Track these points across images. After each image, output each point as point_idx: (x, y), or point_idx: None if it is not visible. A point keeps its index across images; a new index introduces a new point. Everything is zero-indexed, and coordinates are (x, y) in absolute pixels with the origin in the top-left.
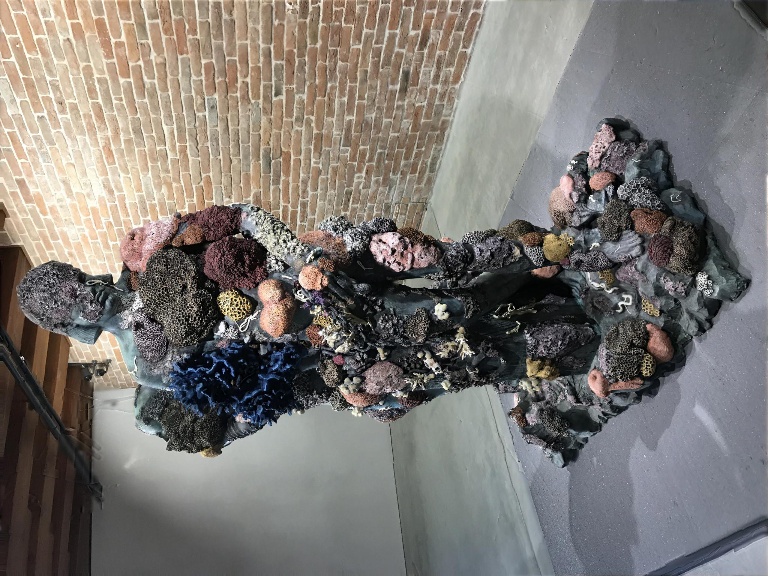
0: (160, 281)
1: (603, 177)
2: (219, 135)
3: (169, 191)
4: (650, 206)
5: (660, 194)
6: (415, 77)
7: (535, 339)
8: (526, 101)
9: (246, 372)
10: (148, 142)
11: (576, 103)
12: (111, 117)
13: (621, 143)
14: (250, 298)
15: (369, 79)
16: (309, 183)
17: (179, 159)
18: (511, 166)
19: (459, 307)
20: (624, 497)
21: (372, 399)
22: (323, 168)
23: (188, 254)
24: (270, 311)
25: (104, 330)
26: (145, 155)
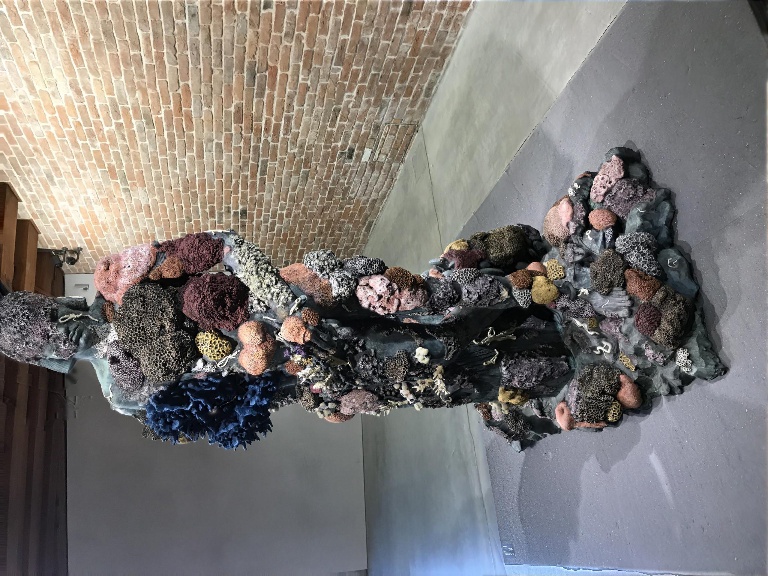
0: (137, 320)
1: (604, 217)
2: (200, 44)
3: (144, 97)
4: (646, 270)
5: (658, 253)
6: (420, 0)
7: (511, 373)
8: (536, 62)
9: (223, 401)
10: (121, 46)
11: (589, 105)
12: (79, 18)
13: (628, 185)
14: (230, 339)
15: None
16: (295, 98)
17: (155, 65)
18: (511, 125)
19: (440, 349)
20: (572, 498)
21: (345, 418)
22: (311, 85)
23: (166, 286)
24: (250, 354)
25: None
26: (118, 59)
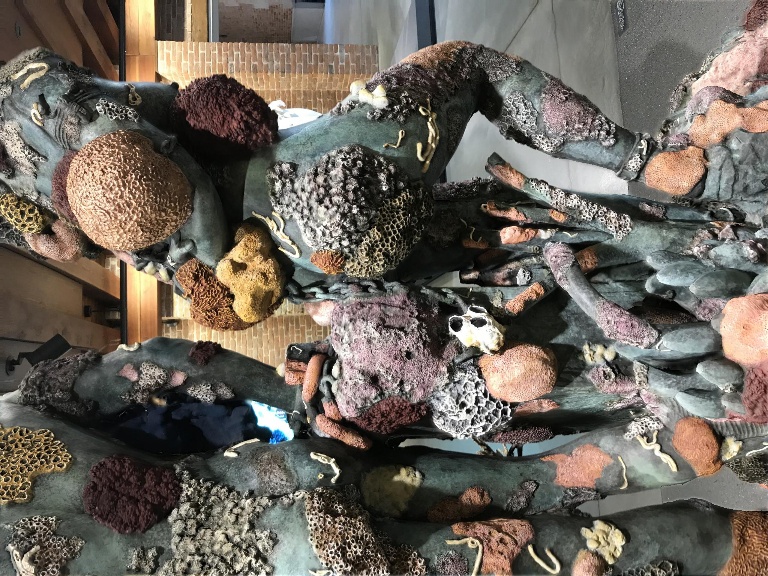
0: None
1: None
2: None
3: None
4: None
5: None
6: None
7: None
8: None
9: None
10: None
11: None
12: None
13: None
14: None
15: None
16: None
17: None
18: None
19: None
20: None
21: None
22: None
23: None
24: None
25: None
26: None
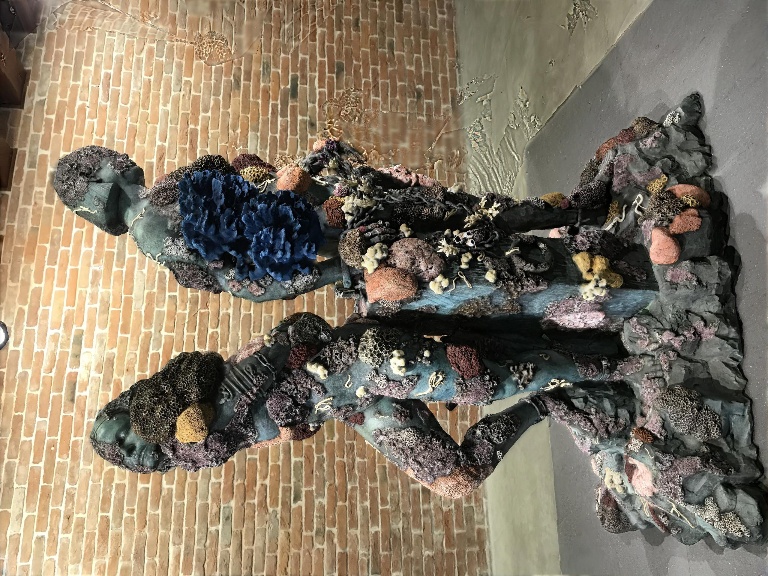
0: None
1: None
2: (230, 560)
3: None
4: None
5: None
6: None
7: None
8: None
9: None
10: (148, 572)
11: None
12: (116, 533)
13: None
14: None
15: (389, 477)
16: None
17: None
18: (549, 458)
19: None
20: None
21: (405, 273)
22: None
23: None
24: None
25: (122, 197)
26: None
